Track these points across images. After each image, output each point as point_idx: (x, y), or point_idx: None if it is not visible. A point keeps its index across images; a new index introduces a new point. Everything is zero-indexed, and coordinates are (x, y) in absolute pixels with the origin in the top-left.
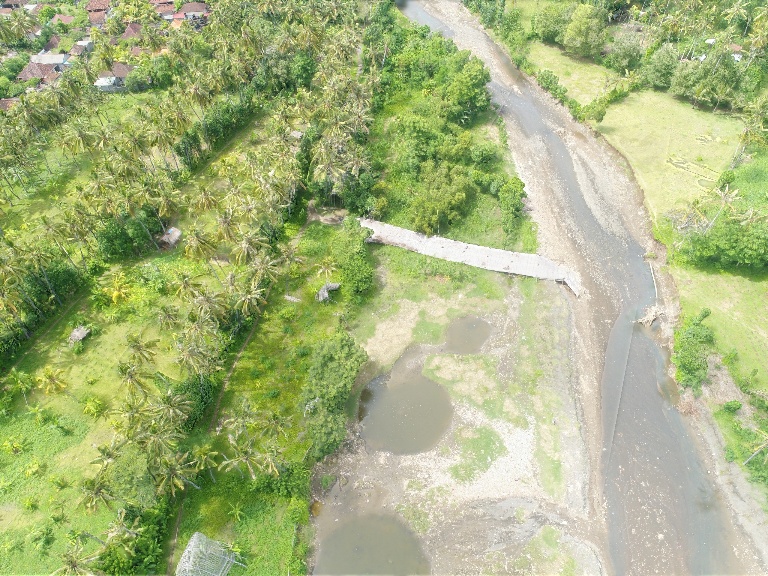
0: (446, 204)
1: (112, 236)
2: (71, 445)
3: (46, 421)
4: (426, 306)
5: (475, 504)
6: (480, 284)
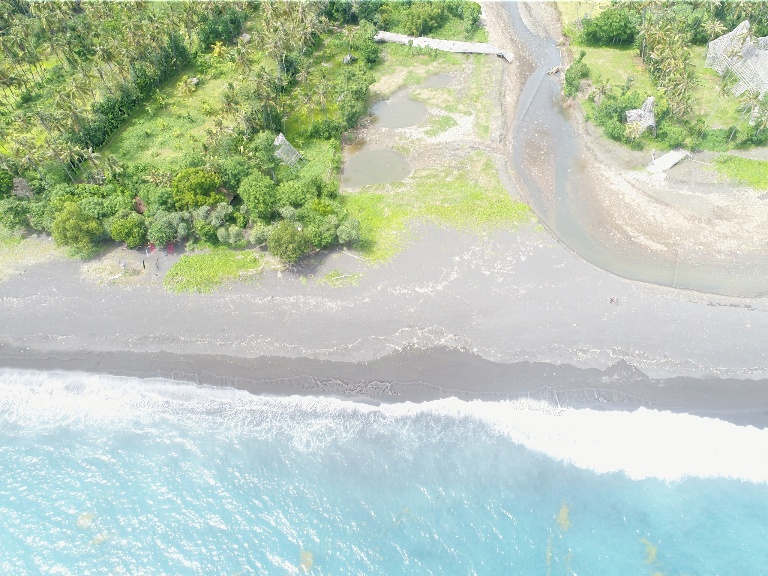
0: (427, 14)
1: (207, 33)
2: (196, 127)
3: (179, 118)
4: (413, 69)
5: (437, 144)
6: (448, 58)
